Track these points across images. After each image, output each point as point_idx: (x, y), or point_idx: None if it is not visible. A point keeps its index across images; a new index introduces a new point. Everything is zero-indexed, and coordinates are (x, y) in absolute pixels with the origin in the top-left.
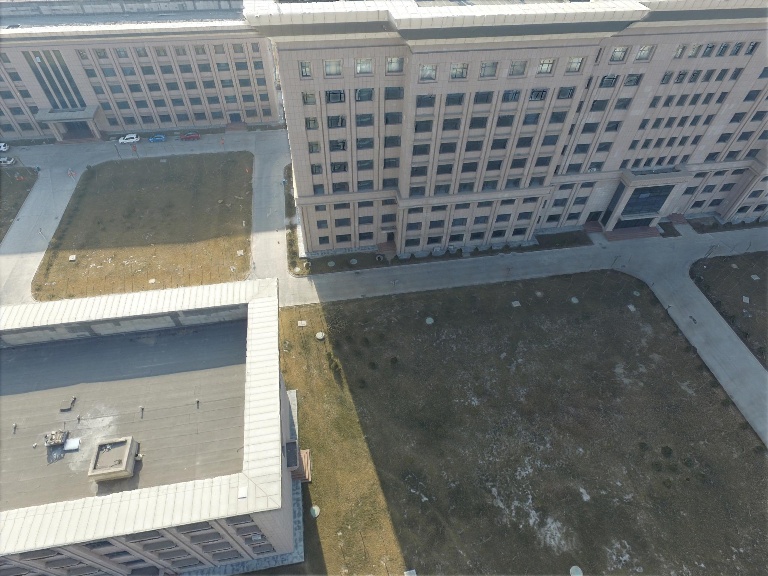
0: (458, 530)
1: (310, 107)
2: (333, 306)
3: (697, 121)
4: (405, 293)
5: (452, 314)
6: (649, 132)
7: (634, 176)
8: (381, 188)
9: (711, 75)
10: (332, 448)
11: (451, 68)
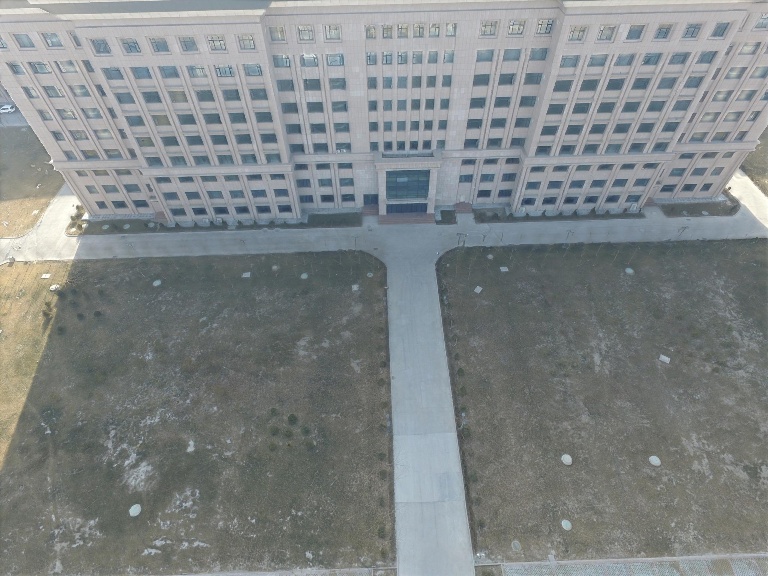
0: (59, 461)
1: (22, 77)
2: (82, 263)
3: (433, 105)
4: (152, 257)
5: (181, 279)
6: (383, 114)
7: (380, 159)
8: (130, 157)
9: (422, 57)
10: (1, 381)
11: (120, 42)
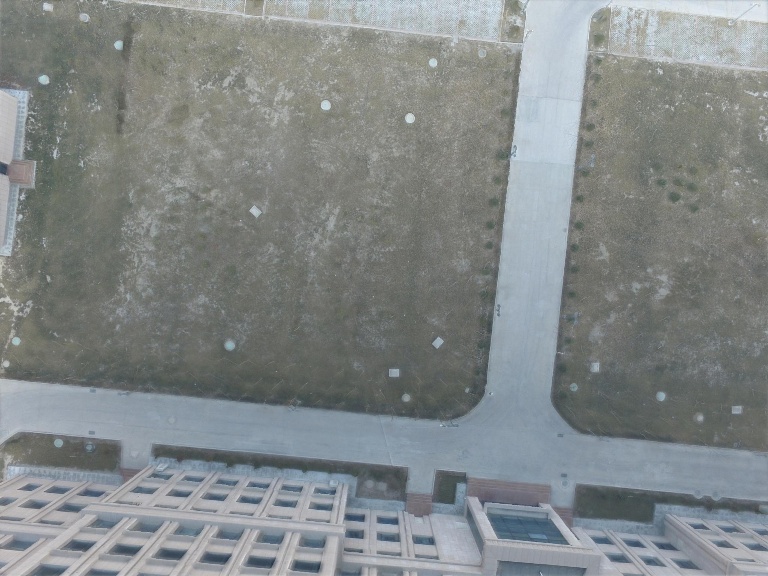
0: None
1: None
2: None
3: None
4: None
5: None
6: None
7: (591, 567)
8: None
9: None
10: None
11: None
